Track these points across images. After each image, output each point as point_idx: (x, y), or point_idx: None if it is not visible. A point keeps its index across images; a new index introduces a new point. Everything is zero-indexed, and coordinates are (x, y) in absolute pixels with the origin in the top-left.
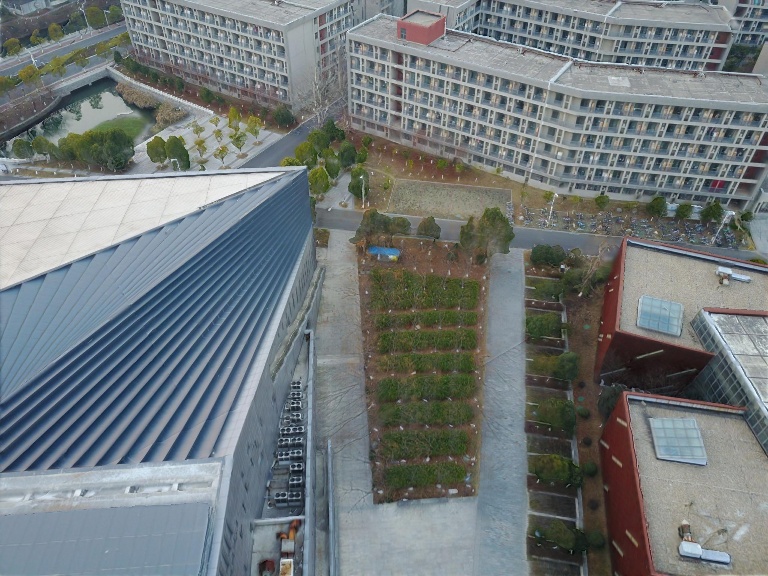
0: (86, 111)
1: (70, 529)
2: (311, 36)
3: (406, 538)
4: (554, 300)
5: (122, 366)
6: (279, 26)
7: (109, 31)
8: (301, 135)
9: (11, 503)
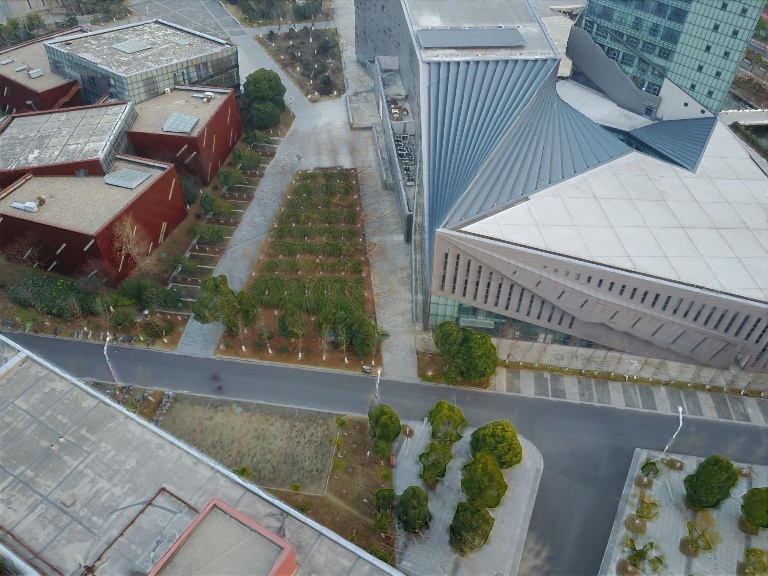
0: None
1: (472, 42)
2: None
3: (339, 157)
4: (176, 286)
5: None
6: None
7: None
8: None
9: (504, 53)
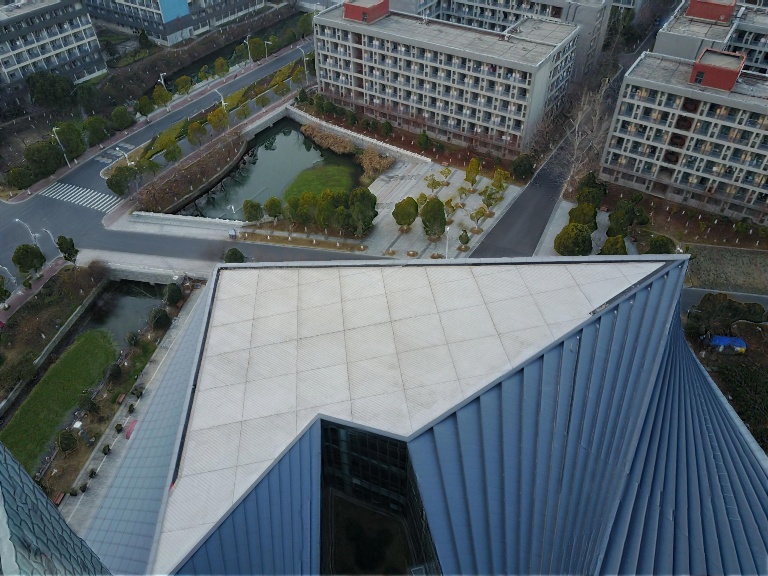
0: (261, 153)
1: None
2: (547, 75)
3: None
4: None
5: (675, 575)
6: (529, 67)
7: (268, 63)
8: (543, 187)
9: None
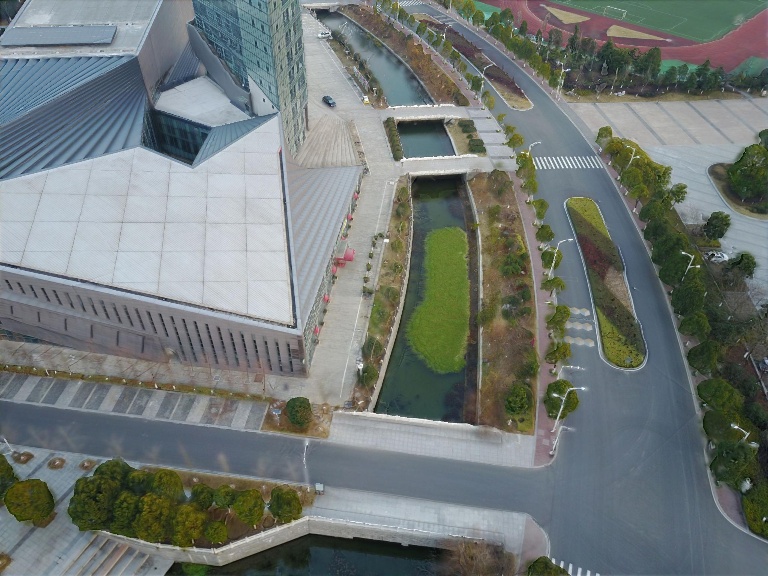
0: None
1: None
2: None
3: None
4: None
5: None
6: None
7: None
8: None
9: (85, 51)
